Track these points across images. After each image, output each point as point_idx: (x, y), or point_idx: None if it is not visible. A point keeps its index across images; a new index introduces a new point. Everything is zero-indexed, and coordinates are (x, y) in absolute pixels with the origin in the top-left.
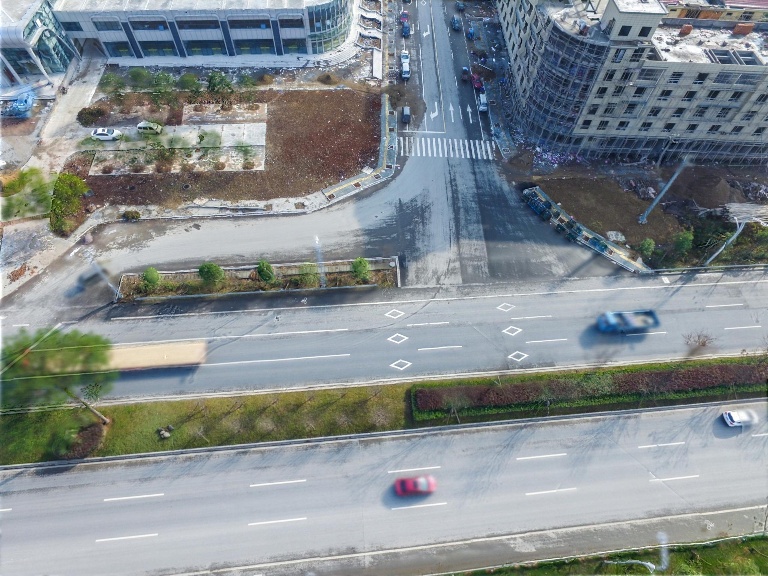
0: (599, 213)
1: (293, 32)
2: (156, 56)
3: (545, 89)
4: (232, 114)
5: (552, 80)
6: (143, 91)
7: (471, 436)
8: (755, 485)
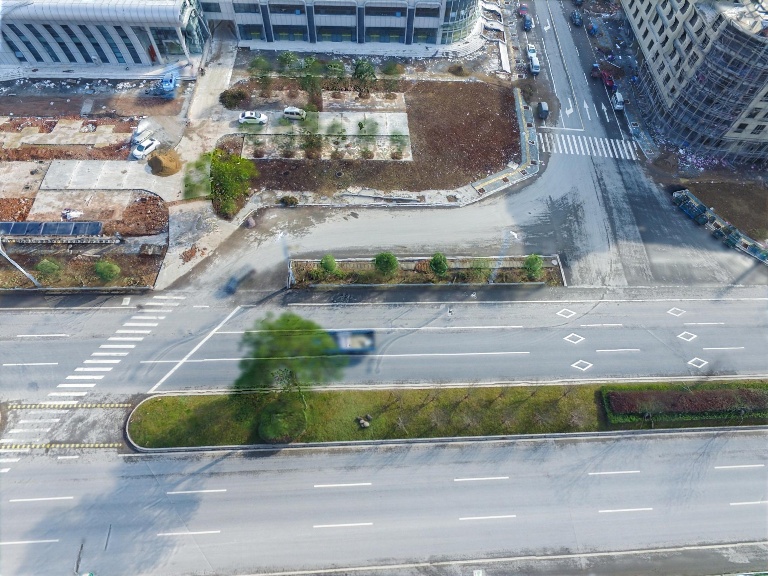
0: (754, 220)
1: (427, 21)
2: (286, 40)
3: (704, 90)
4: (371, 102)
5: (716, 81)
6: (278, 75)
7: (665, 442)
8: None
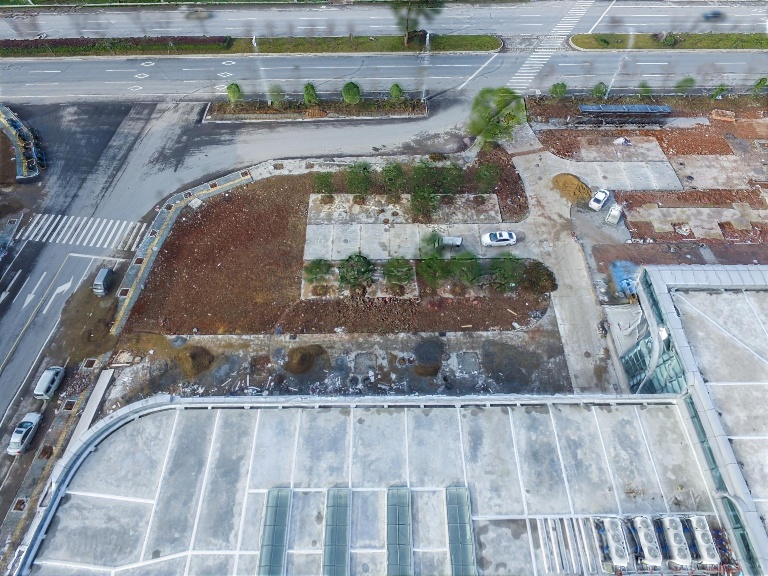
0: None
1: None
2: None
3: None
4: None
5: None
6: (489, 333)
7: None
8: (61, 18)
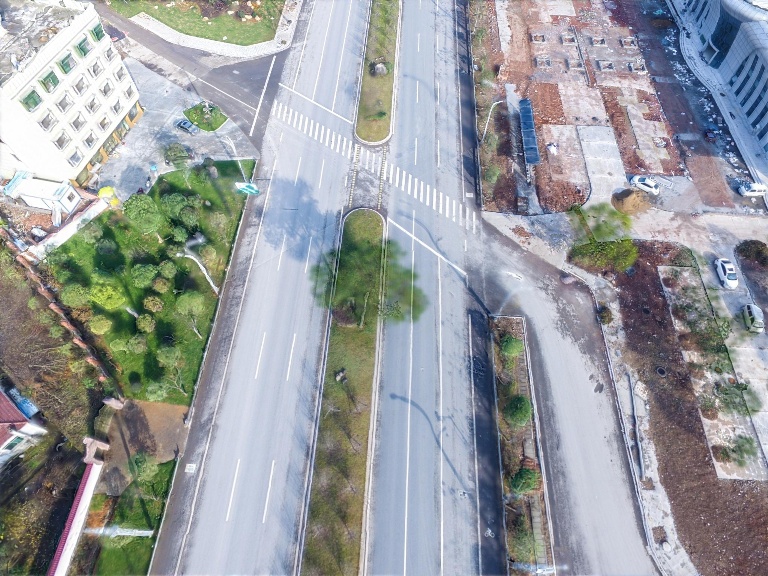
0: None
1: None
2: None
3: None
4: None
5: None
6: None
7: None
8: None
